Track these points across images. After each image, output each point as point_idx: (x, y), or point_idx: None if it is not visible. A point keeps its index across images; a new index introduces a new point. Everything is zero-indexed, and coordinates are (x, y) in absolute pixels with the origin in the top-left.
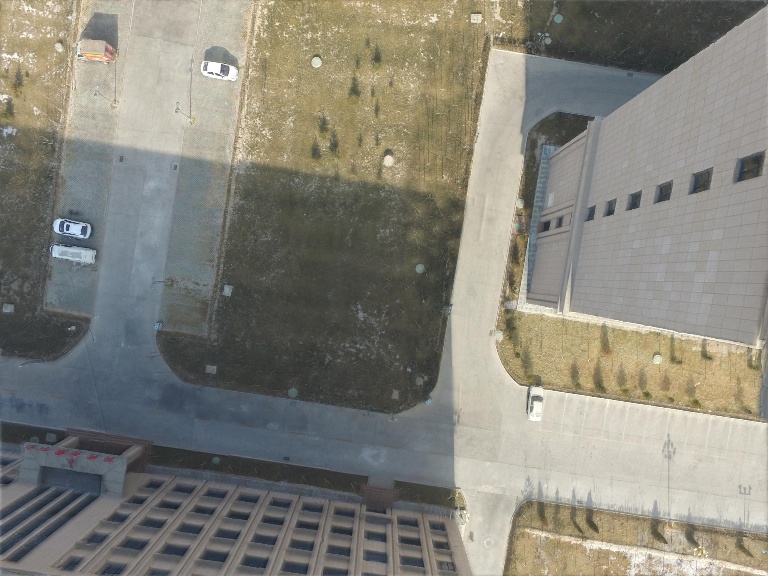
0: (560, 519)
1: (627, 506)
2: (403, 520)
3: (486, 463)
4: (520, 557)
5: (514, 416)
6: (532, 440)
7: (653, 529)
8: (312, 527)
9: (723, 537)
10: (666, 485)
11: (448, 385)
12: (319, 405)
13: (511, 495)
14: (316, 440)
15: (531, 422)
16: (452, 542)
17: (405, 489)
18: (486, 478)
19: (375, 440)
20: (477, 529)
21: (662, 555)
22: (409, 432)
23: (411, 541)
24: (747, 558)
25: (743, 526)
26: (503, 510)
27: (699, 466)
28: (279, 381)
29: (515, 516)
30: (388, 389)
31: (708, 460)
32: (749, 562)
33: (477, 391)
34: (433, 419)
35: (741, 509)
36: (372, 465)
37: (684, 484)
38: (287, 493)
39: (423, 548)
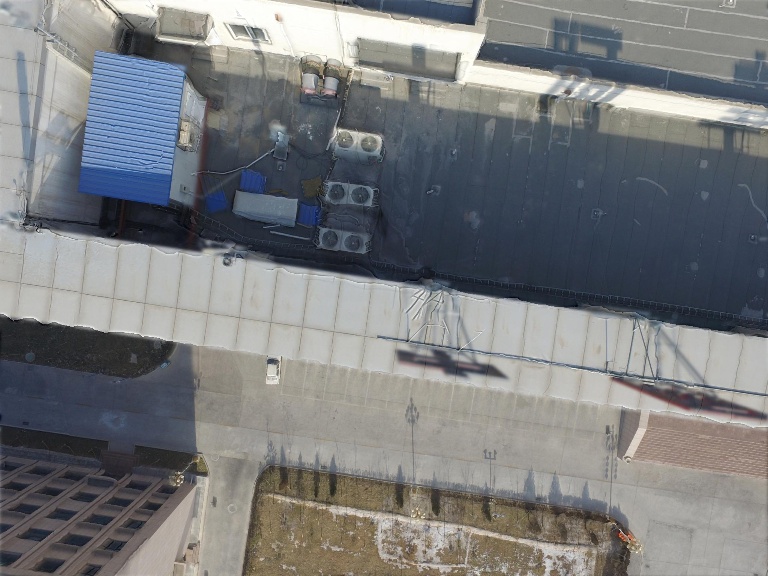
0: (303, 484)
1: (371, 471)
2: (137, 484)
3: (228, 428)
4: (265, 523)
5: (255, 380)
6: (274, 404)
7: (398, 494)
8: (21, 488)
9: (469, 502)
10: (410, 450)
11: (187, 349)
12: (57, 369)
13: (254, 460)
14: (55, 405)
15: (272, 386)
16: (165, 504)
17: (146, 454)
18: (228, 443)
19: (115, 405)
20: (220, 494)
21: (408, 521)
22: (149, 396)
23: (125, 503)
24: (494, 523)
25: (489, 491)
26: (246, 475)
27: (443, 430)
28: (16, 345)
29: (258, 481)
30: (126, 353)
31: (452, 424)
32: (496, 528)
33: (217, 355)
34: (173, 383)
35: (487, 474)
36: (112, 430)
37: (428, 449)
38: (25, 458)
39: (125, 508)
